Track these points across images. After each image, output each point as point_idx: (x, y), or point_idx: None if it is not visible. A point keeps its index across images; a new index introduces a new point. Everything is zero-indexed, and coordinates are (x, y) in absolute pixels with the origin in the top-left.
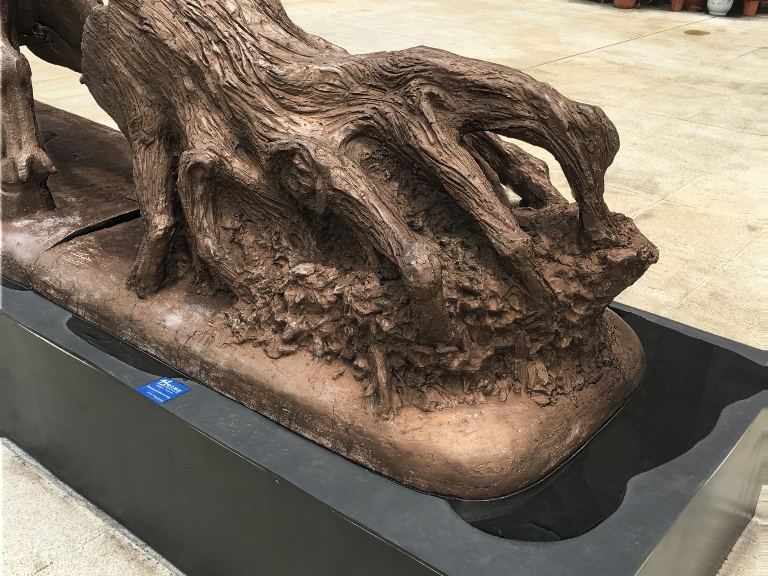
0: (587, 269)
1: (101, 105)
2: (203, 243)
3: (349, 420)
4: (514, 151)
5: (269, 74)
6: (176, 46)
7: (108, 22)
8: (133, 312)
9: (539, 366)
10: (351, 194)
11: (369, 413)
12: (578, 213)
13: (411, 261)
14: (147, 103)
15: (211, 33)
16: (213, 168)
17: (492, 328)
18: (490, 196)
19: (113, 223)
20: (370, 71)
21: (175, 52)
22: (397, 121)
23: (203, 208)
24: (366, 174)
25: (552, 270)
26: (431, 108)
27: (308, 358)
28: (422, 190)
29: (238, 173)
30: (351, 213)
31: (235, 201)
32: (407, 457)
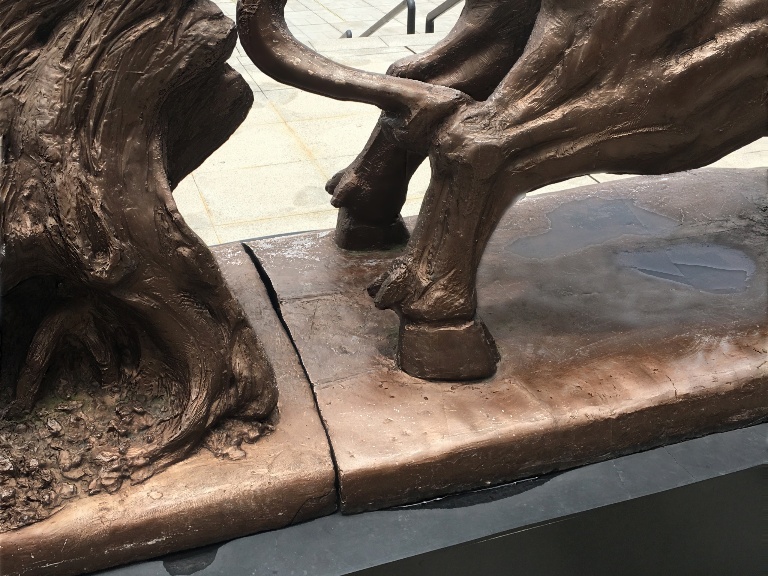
0: None
1: None
2: None
3: None
4: None
5: None
6: None
7: None
8: None
9: None
10: None
11: None
12: None
13: None
14: None
15: None
16: None
17: None
18: None
19: None
20: None
21: None
22: None
23: None
24: None
25: None
26: None
27: None
28: None
29: None
30: None
31: None
32: None
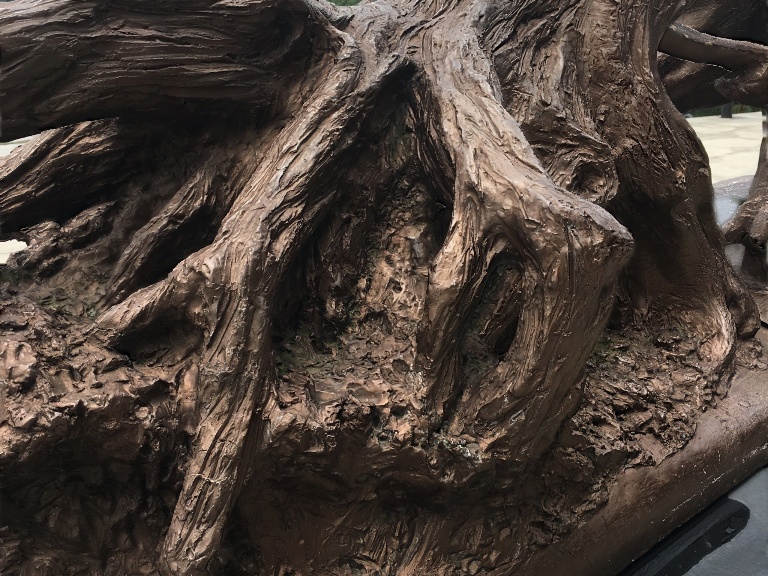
0: None
1: None
2: None
3: None
4: None
5: None
6: None
7: None
8: None
9: None
10: None
11: None
12: None
13: None
14: None
15: None
16: None
17: None
18: None
19: None
20: None
21: None
22: None
23: None
24: None
25: None
26: None
27: None
28: None
29: None
30: None
31: None
32: None
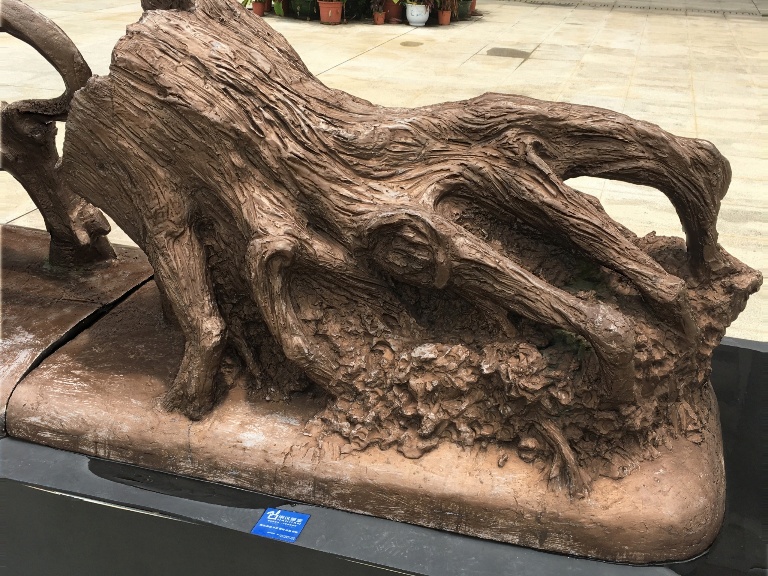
0: (716, 300)
1: (87, 196)
2: (292, 343)
3: (539, 508)
4: None
5: (337, 139)
6: (218, 117)
7: (112, 95)
8: (190, 439)
9: (685, 405)
10: (485, 262)
11: (560, 495)
12: (684, 246)
13: (609, 326)
14: (172, 187)
15: (253, 98)
16: (294, 255)
17: (658, 378)
18: (630, 243)
19: (74, 333)
20: (447, 125)
21: (218, 124)
22: (497, 176)
23: (284, 302)
24: None
25: None
26: None
27: (456, 449)
28: (527, 245)
29: (322, 256)
30: (482, 282)
31: (309, 288)
32: (617, 533)
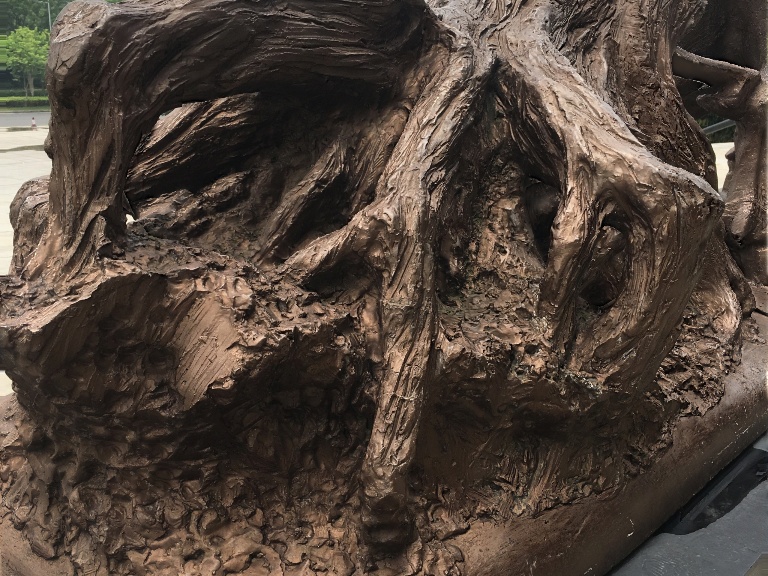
0: None
1: None
2: None
3: None
4: None
5: None
6: None
7: None
8: None
9: None
10: None
11: None
12: None
13: None
14: None
15: None
16: None
17: None
18: None
19: None
20: None
21: None
22: None
23: None
24: None
25: None
26: None
27: None
28: None
29: None
30: None
31: None
32: None
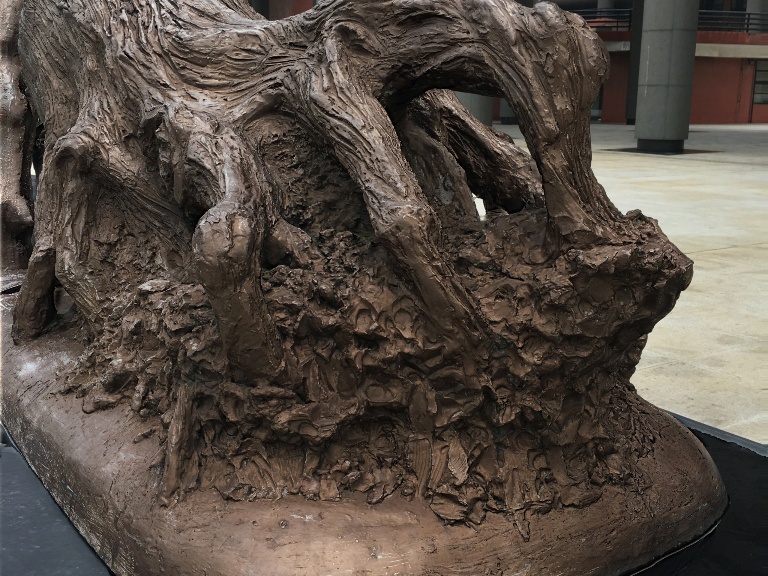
0: (544, 280)
1: None
2: (60, 256)
3: (121, 504)
4: (509, 150)
5: (174, 40)
6: (83, 18)
7: (35, 7)
8: (1, 360)
9: (454, 451)
10: (203, 163)
11: (148, 494)
12: None
13: (201, 221)
14: (62, 100)
15: (128, 3)
16: (85, 157)
17: (357, 364)
18: (385, 152)
19: None
20: (293, 26)
21: (81, 25)
22: (303, 77)
23: (71, 212)
24: (251, 150)
25: (492, 286)
26: (338, 46)
27: (124, 413)
28: (332, 177)
29: (114, 164)
30: (207, 194)
31: (120, 209)
32: (171, 574)
